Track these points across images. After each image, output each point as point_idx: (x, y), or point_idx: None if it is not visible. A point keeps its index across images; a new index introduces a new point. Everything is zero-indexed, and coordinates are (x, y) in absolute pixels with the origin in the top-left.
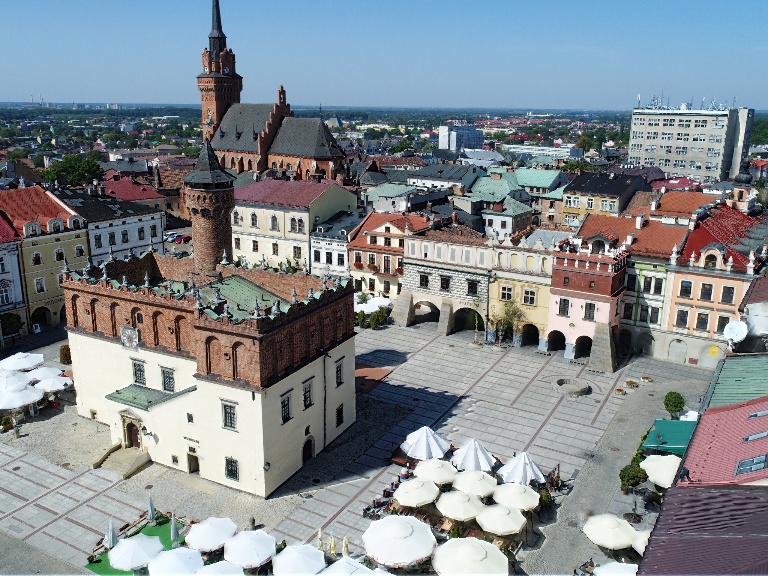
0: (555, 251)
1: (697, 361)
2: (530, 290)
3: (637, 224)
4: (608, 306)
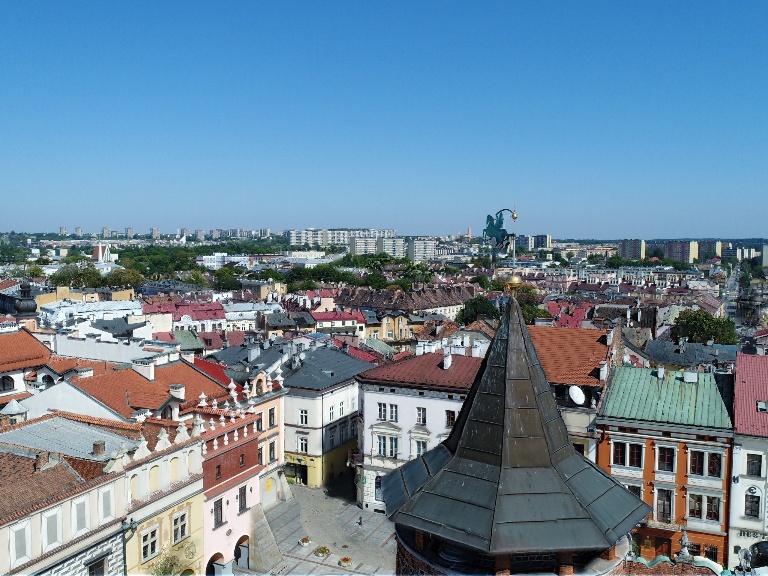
0: (203, 433)
1: (261, 505)
2: (181, 515)
3: (151, 373)
4: (258, 479)
